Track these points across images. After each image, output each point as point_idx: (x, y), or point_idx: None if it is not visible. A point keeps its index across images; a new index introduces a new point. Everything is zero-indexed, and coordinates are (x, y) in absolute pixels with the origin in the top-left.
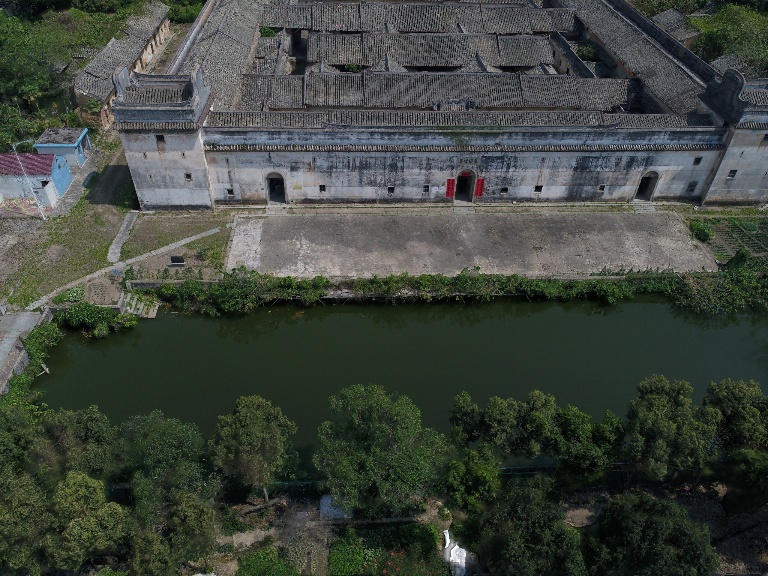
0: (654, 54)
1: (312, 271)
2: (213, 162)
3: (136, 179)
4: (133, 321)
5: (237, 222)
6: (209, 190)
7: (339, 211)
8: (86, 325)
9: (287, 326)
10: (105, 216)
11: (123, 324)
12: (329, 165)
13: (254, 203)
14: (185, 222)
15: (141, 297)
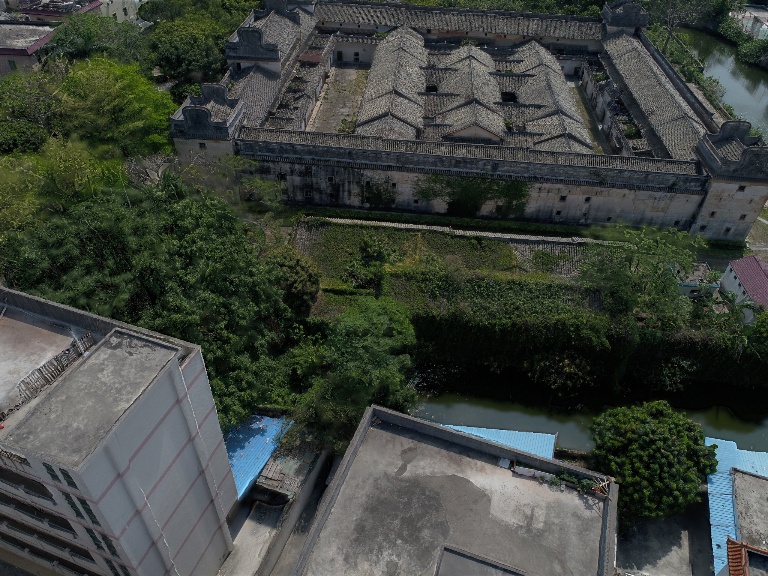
0: (524, 21)
1: None
2: None
3: None
4: None
5: None
6: None
7: None
8: None
9: None
10: (761, 259)
11: None
12: None
13: None
14: None
15: None
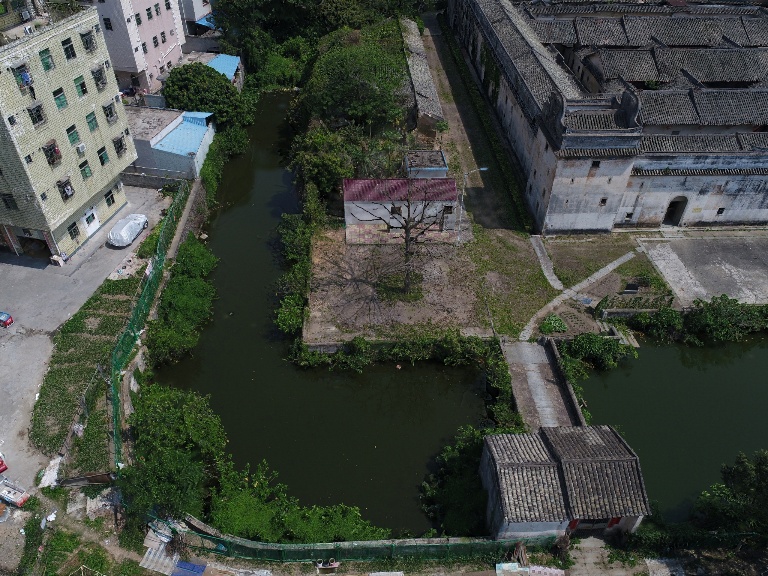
0: None
1: (764, 298)
2: (627, 186)
3: (552, 204)
4: (635, 352)
5: (644, 246)
6: (616, 214)
7: (734, 234)
8: (589, 356)
9: (744, 354)
10: (511, 241)
11: (628, 355)
12: (738, 188)
13: (647, 226)
14: (593, 247)
15: (616, 326)
